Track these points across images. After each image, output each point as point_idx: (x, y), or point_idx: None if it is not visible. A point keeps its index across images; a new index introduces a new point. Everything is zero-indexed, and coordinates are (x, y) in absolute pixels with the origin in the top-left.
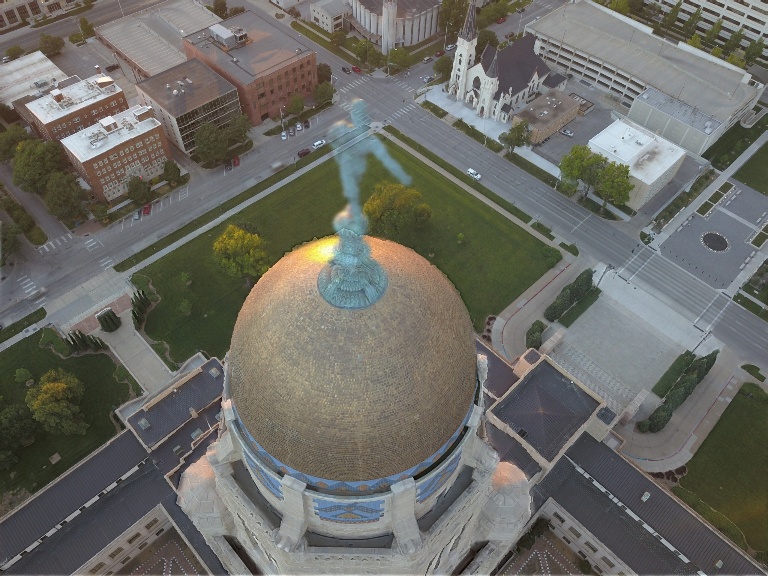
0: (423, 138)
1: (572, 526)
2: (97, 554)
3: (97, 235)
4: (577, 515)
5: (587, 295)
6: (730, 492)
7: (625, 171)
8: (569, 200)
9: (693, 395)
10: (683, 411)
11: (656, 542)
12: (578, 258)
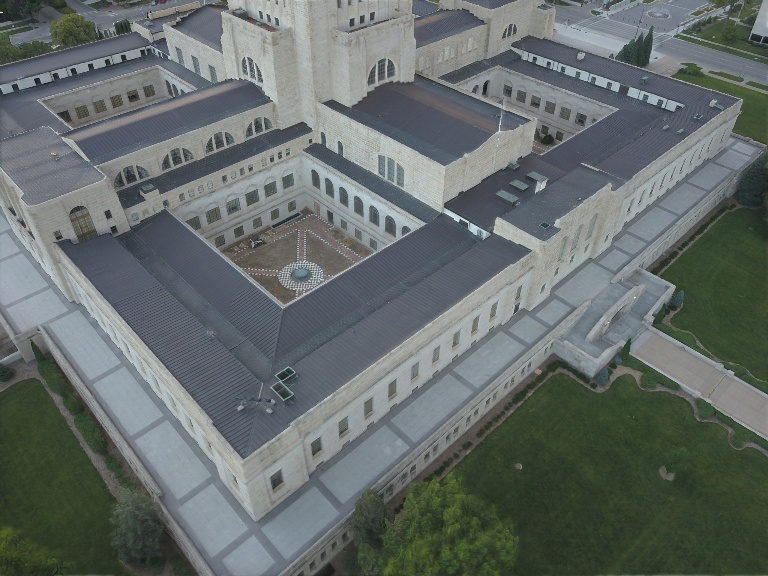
0: None
1: (518, 89)
2: (101, 81)
3: (119, 11)
4: (521, 72)
5: None
6: None
7: None
8: None
9: None
10: None
11: (592, 86)
12: None
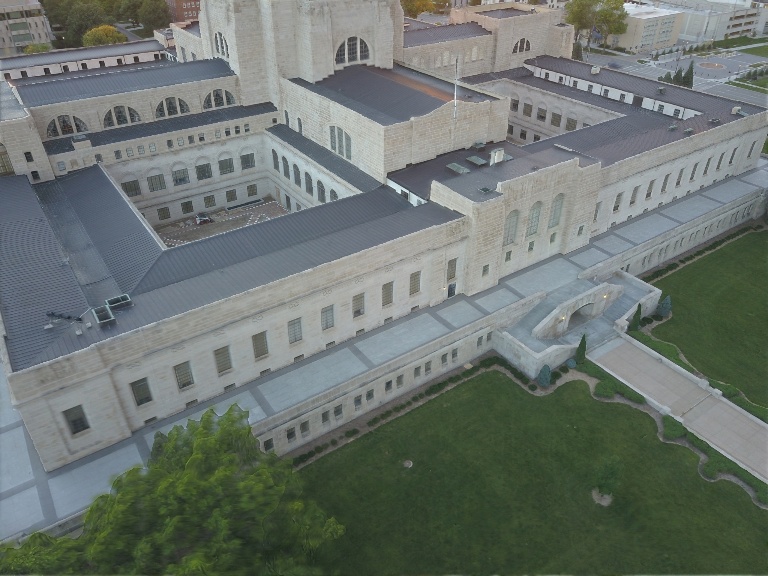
0: None
1: (525, 102)
2: None
3: None
4: (528, 84)
5: None
6: None
7: None
8: None
9: None
10: None
11: (604, 99)
12: None
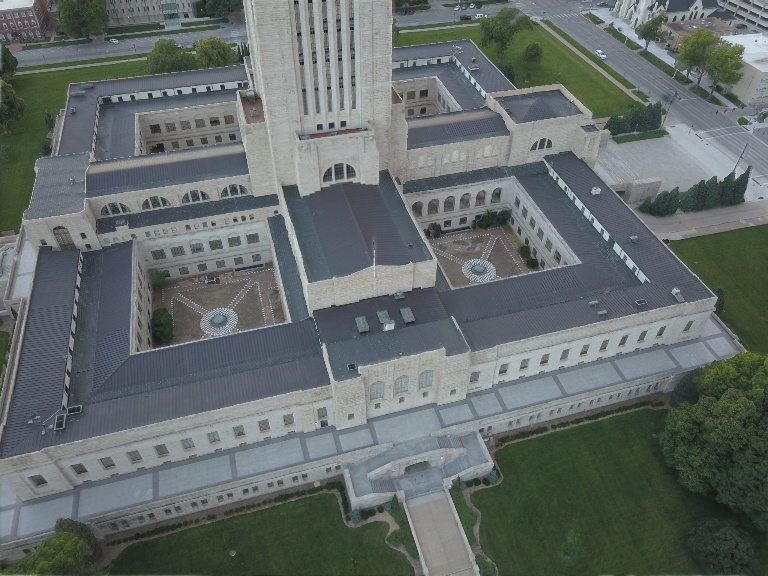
0: (571, 31)
1: (524, 205)
2: (188, 107)
3: None
4: (529, 190)
5: (652, 132)
6: (704, 267)
7: (738, 51)
8: (682, 86)
9: (714, 211)
10: (695, 216)
11: (589, 226)
12: (663, 116)
